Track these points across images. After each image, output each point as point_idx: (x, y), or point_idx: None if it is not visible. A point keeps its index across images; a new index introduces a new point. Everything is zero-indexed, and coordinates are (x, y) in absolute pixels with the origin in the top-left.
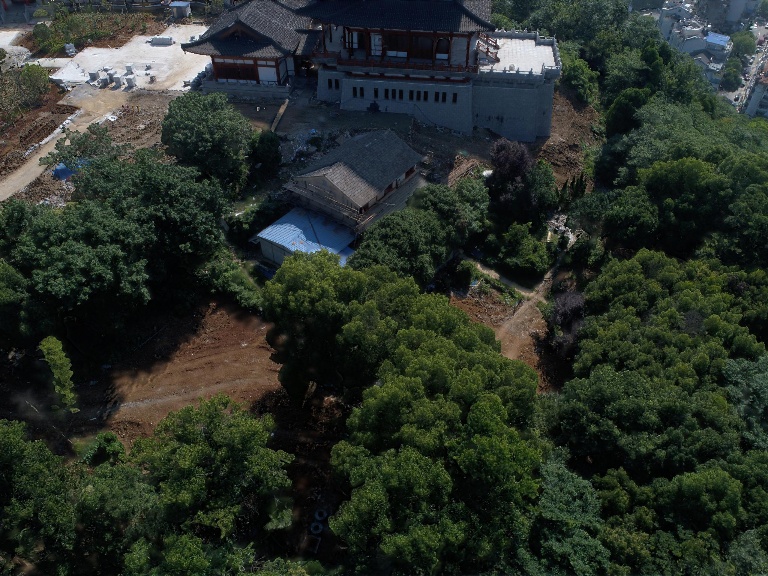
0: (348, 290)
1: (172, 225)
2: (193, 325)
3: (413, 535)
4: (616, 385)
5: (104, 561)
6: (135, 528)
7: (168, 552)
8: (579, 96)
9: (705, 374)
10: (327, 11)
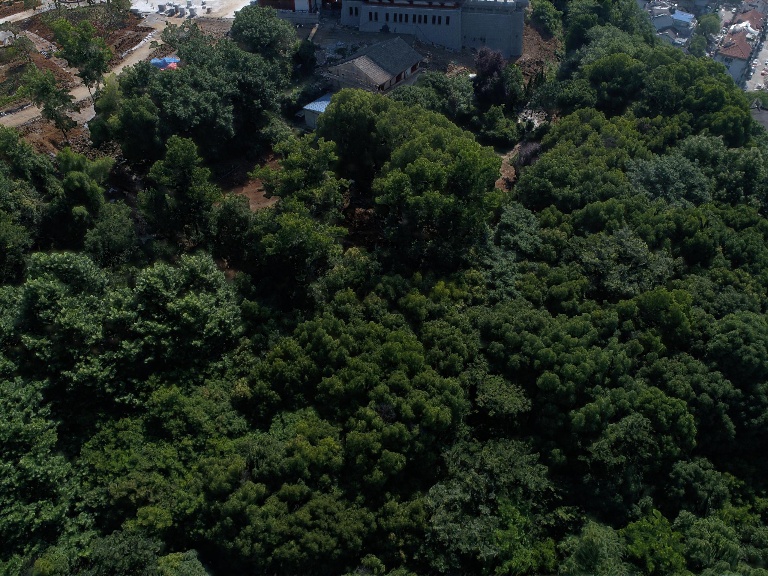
0: (378, 105)
1: (247, 89)
2: None
3: (425, 196)
4: None
5: (234, 246)
6: (256, 219)
7: (287, 203)
8: (546, 28)
9: (613, 167)
10: None
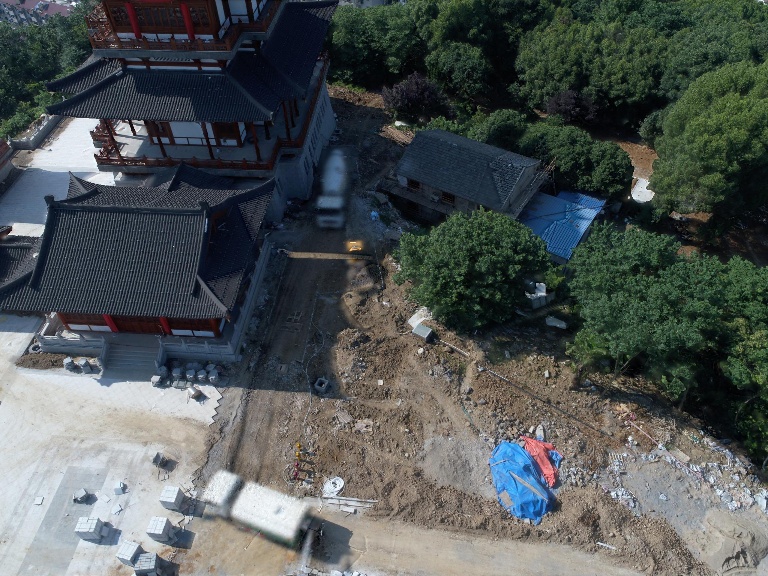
0: None
1: None
2: None
3: None
4: None
5: None
6: None
7: None
8: None
9: None
10: (264, 96)
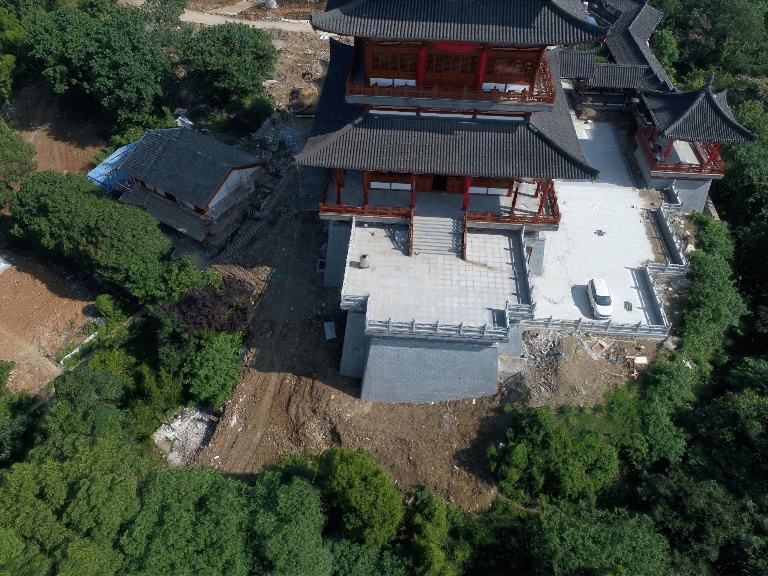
0: None
1: None
2: (92, 143)
3: None
4: None
5: None
6: None
7: None
8: None
9: None
10: None
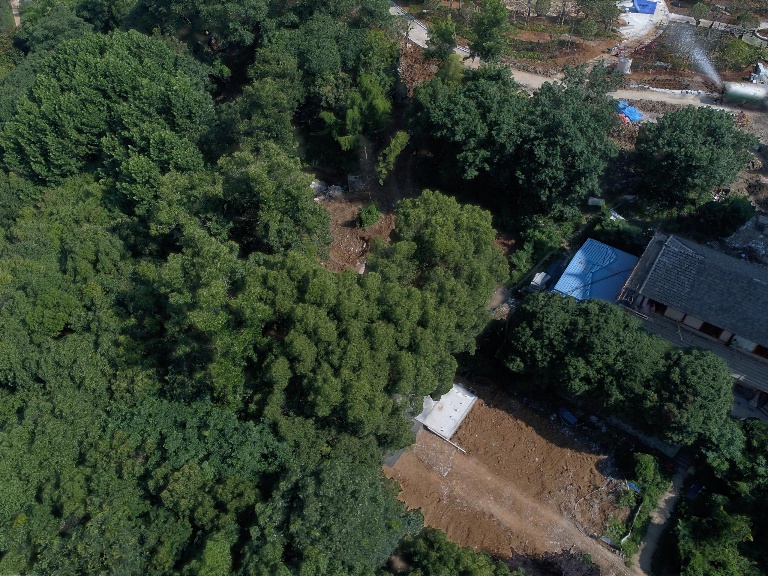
0: (423, 235)
1: None
2: None
3: None
4: None
5: None
6: None
7: None
8: None
9: None
10: None
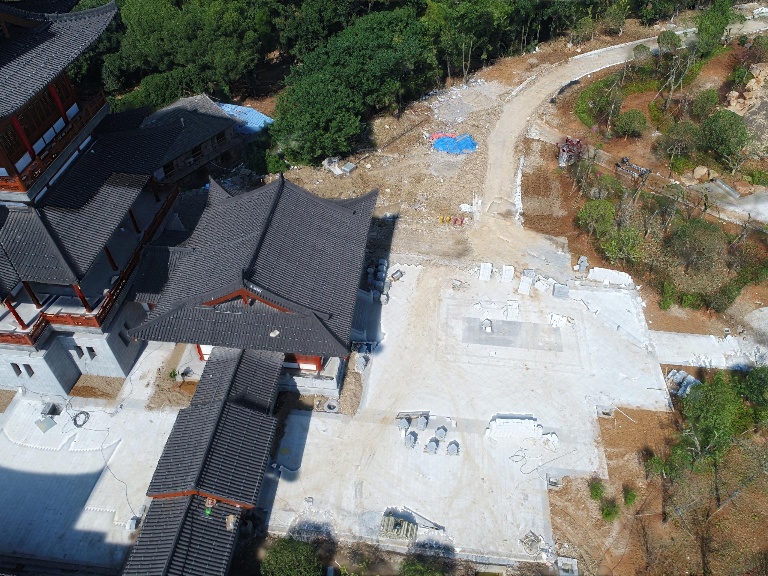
0: None
1: None
2: None
3: None
4: (88, 4)
5: None
6: None
7: None
8: None
9: None
10: None
